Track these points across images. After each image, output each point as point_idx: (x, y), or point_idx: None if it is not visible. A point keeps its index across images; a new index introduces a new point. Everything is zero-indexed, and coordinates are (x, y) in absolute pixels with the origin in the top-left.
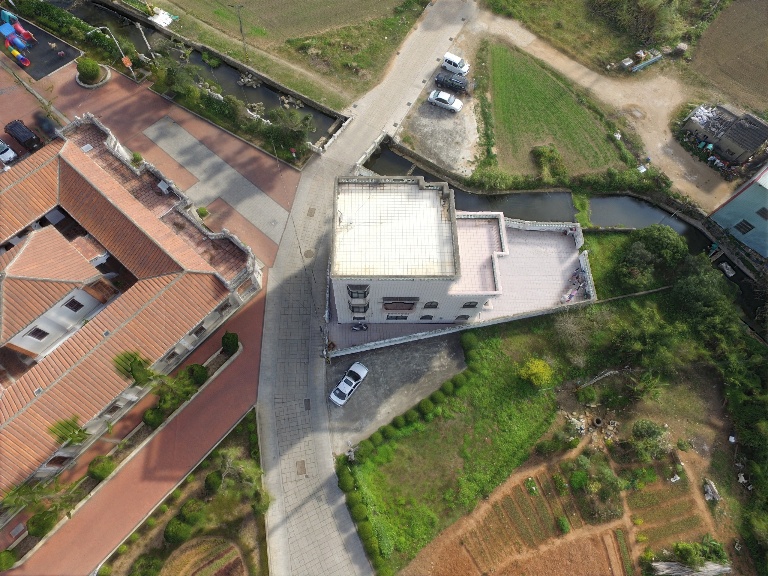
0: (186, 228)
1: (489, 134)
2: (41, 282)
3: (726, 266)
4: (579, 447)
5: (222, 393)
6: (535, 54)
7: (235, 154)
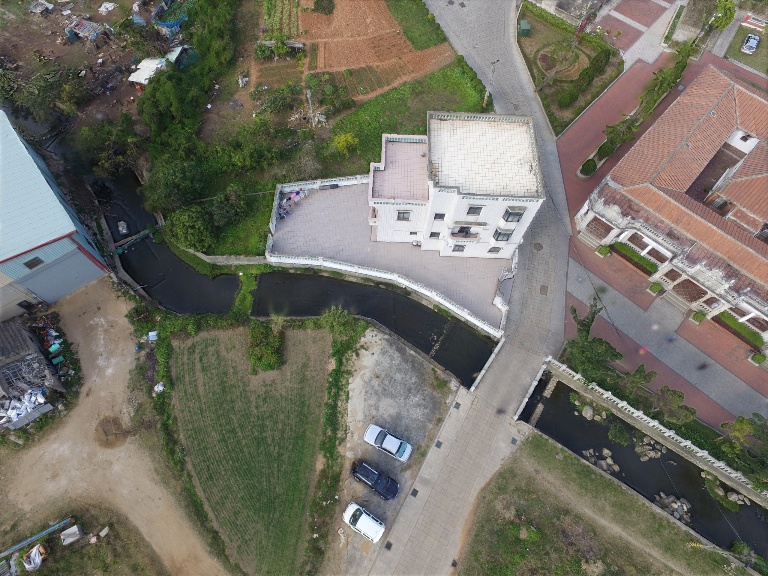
0: (665, 234)
1: (335, 387)
2: (762, 173)
3: (123, 229)
4: (323, 108)
5: (583, 147)
6: (218, 570)
7: (649, 368)
